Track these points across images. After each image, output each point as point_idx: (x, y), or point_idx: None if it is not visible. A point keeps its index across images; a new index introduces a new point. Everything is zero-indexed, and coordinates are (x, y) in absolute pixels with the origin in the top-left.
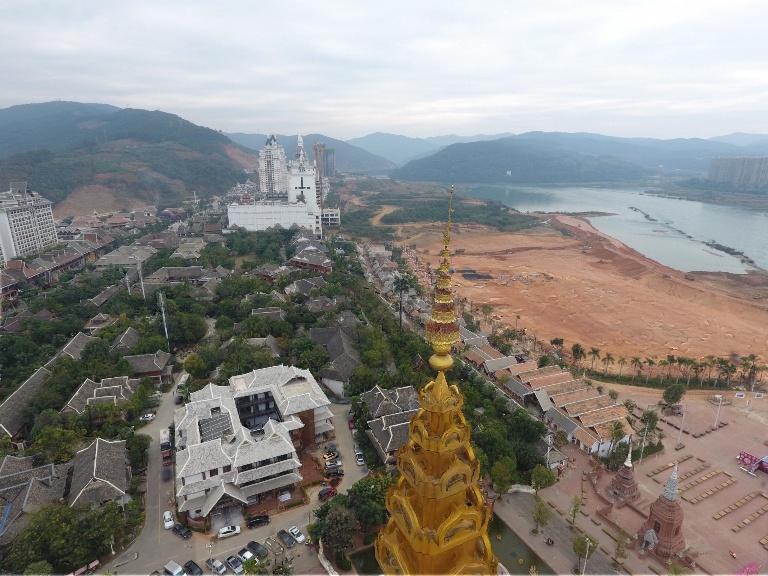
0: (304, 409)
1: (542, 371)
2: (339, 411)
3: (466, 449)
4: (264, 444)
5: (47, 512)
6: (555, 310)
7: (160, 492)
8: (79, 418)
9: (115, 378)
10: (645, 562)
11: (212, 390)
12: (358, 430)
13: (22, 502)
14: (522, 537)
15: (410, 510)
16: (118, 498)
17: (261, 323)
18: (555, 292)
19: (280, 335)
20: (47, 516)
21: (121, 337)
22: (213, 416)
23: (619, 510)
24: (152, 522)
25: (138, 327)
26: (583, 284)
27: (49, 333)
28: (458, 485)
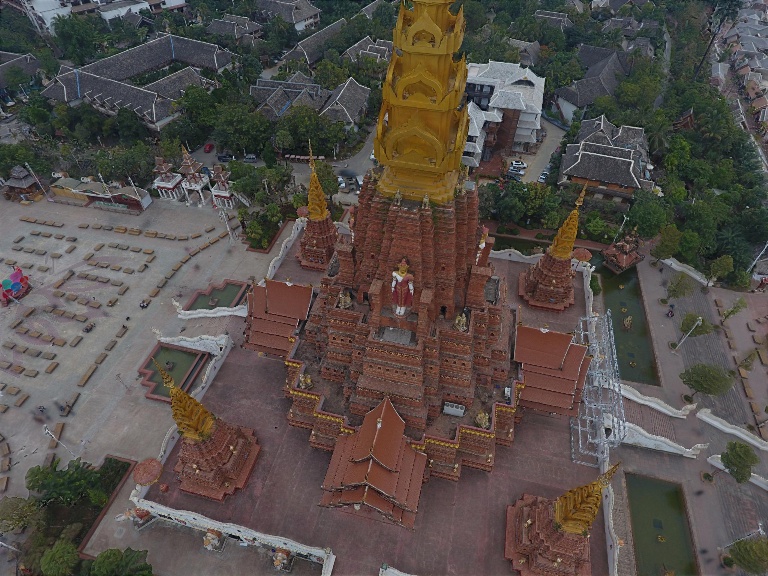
0: (510, 107)
1: None
2: (557, 135)
3: (455, 22)
4: None
5: (301, 107)
6: None
7: None
8: (350, 64)
9: (386, 41)
10: None
11: None
12: (558, 153)
13: (294, 100)
14: (645, 298)
15: (391, 64)
16: (348, 124)
17: (534, 25)
18: None
19: (547, 44)
20: (300, 110)
21: None
22: None
23: None
24: (365, 152)
25: None
26: None
27: None
28: (425, 45)
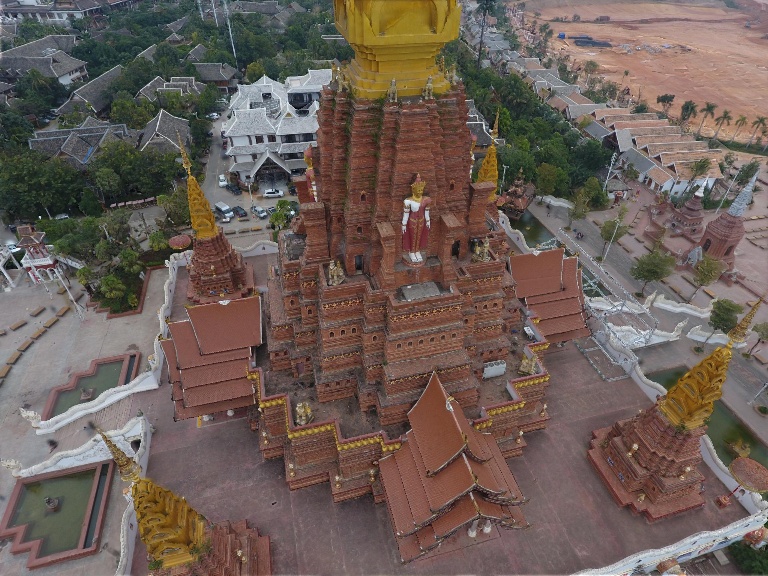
0: None
1: (634, 117)
2: None
3: None
4: (307, 119)
5: (115, 143)
6: (679, 81)
7: (218, 165)
8: (150, 103)
9: (183, 78)
10: (679, 273)
11: (265, 80)
12: None
13: (99, 142)
14: (552, 230)
15: None
16: (179, 156)
17: (327, 45)
18: (687, 64)
19: (346, 59)
20: (115, 146)
21: (191, 50)
22: (264, 101)
23: (671, 238)
24: (210, 182)
25: (208, 46)
26: (729, 58)
27: (129, 47)
28: None
